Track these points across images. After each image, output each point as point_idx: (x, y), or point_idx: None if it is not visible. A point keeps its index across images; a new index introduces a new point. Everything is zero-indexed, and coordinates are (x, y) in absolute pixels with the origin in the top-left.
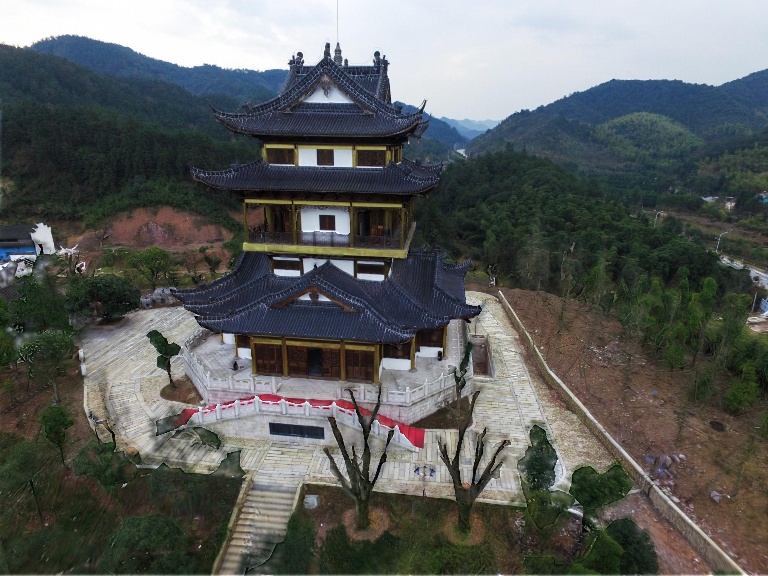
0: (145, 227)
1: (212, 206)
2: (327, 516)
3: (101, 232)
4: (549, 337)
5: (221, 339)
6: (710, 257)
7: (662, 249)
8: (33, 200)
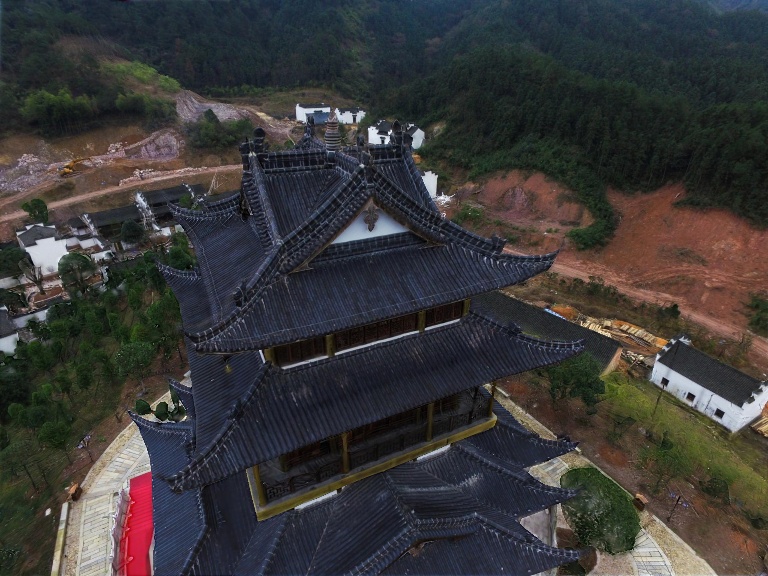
0: (512, 190)
1: (590, 180)
2: None
3: (476, 186)
4: None
5: None
6: None
7: None
8: (448, 145)
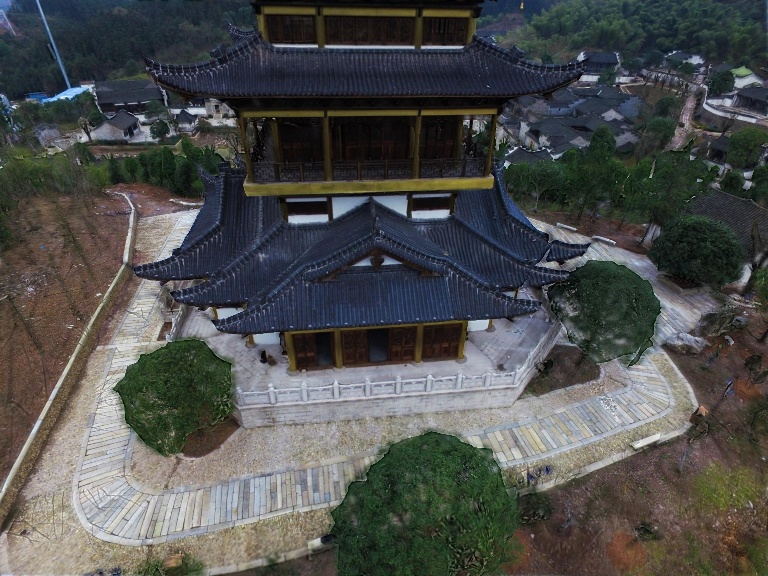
0: None
1: None
2: None
3: None
4: (67, 311)
5: None
6: None
7: None
8: None
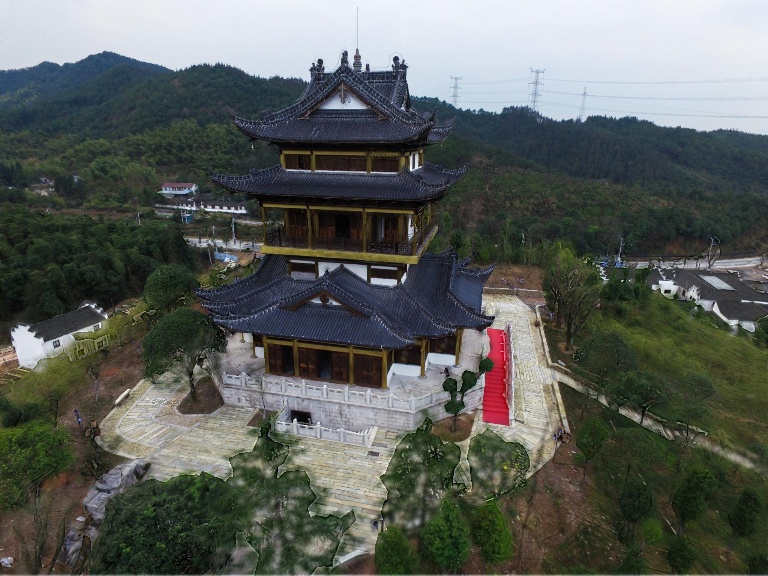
0: None
1: None
2: (568, 360)
3: None
4: None
5: (375, 391)
6: (179, 230)
7: (134, 235)
8: None
